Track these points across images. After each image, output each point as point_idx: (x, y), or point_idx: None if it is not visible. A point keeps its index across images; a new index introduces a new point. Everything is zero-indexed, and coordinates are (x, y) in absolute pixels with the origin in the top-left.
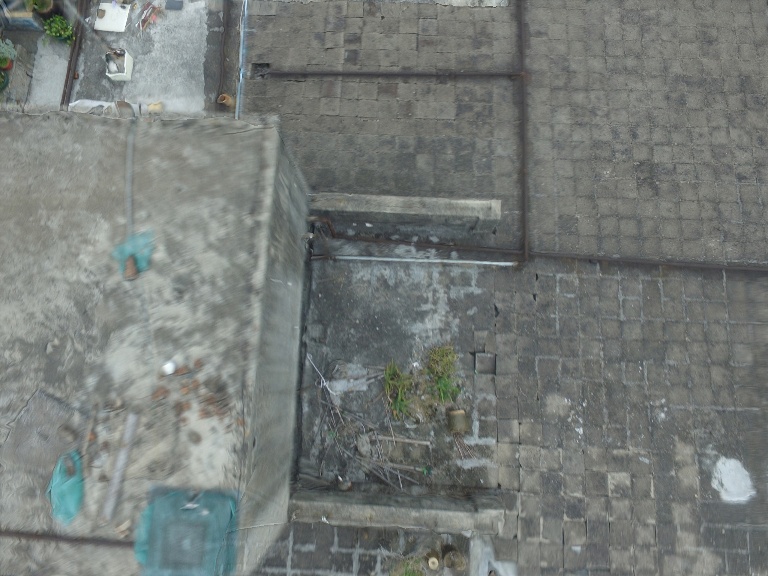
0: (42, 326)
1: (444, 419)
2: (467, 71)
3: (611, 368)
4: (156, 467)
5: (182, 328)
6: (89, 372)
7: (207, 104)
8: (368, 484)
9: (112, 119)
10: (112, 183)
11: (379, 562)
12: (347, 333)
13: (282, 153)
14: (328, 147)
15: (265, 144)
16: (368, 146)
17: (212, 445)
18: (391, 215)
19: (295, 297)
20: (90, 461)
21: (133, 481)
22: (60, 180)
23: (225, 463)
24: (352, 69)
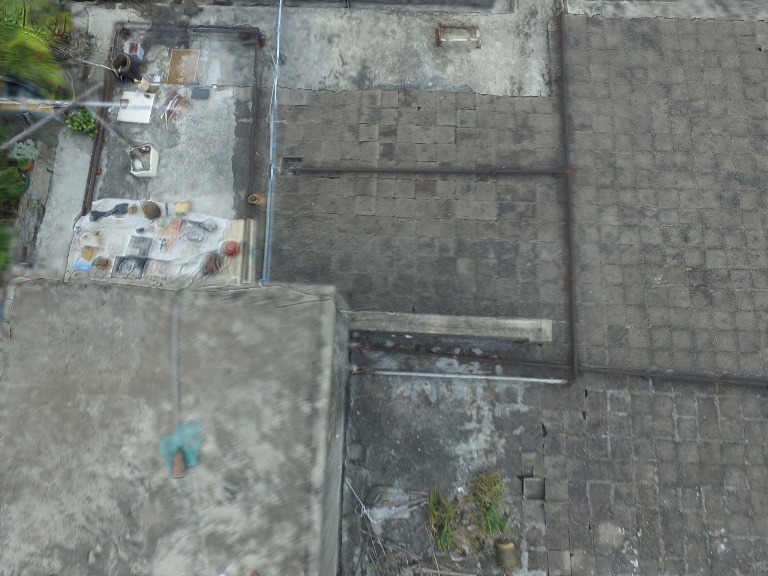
0: (83, 530)
1: (491, 550)
2: (509, 168)
3: (666, 494)
4: None
5: (235, 533)
6: None
7: (236, 202)
8: None
9: (155, 290)
10: (156, 363)
11: None
12: (387, 455)
13: (337, 320)
14: (364, 250)
15: (321, 319)
16: (406, 249)
17: None
18: (435, 334)
19: None
20: None
21: None
22: (100, 359)
23: None
24: (388, 165)
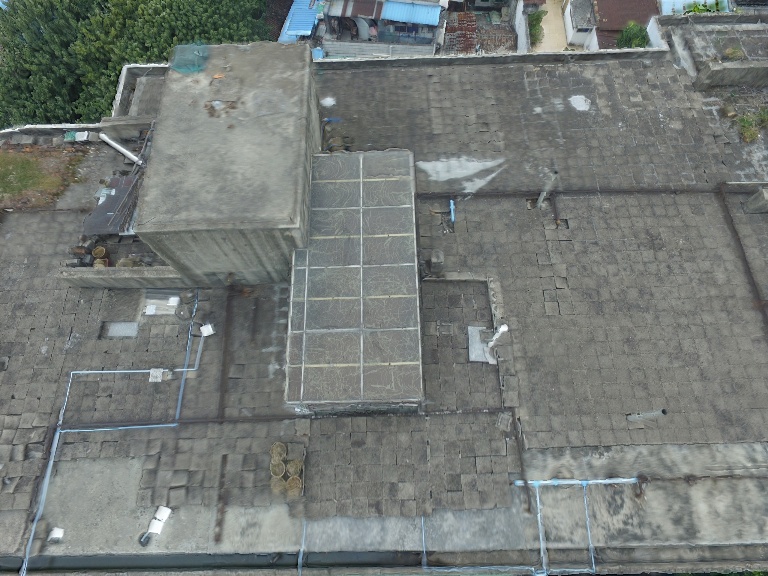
0: None
1: None
2: None
3: (652, 142)
4: None
5: None
6: None
7: None
8: None
9: None
10: None
11: None
12: None
13: None
14: None
15: None
16: None
17: None
18: None
19: None
20: None
21: None
22: None
23: None
24: None
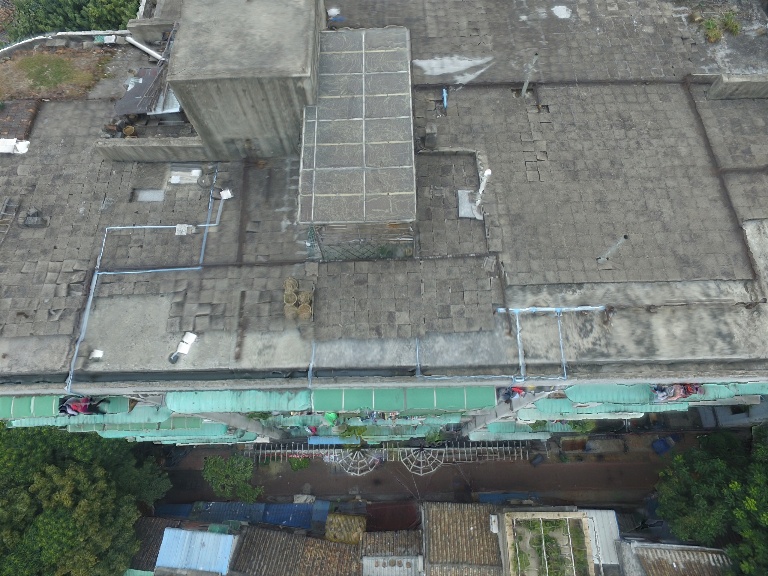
0: None
1: None
2: None
3: (626, 43)
4: None
5: None
6: None
7: None
8: None
9: None
10: None
11: None
12: (763, 46)
13: None
14: None
15: None
16: None
17: None
18: None
19: None
20: None
21: None
22: None
23: None
24: None
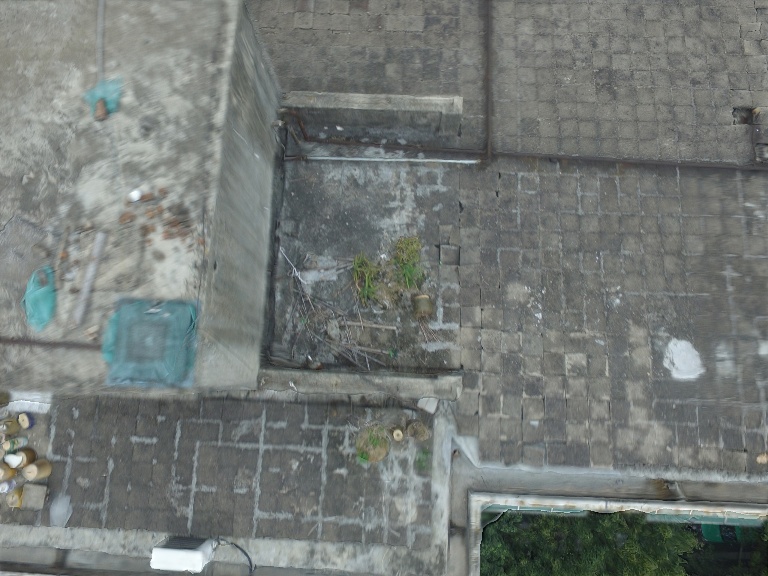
0: (18, 161)
1: (410, 306)
2: None
3: (569, 258)
4: (122, 279)
5: (148, 162)
6: (62, 201)
7: None
8: (337, 367)
9: None
10: (84, 36)
11: (347, 437)
12: (318, 228)
13: (245, 15)
14: (301, 58)
15: (227, 1)
16: (340, 56)
17: (175, 262)
18: (359, 112)
19: (264, 178)
20: (62, 274)
21: (101, 293)
22: (36, 34)
23: (186, 277)
24: None
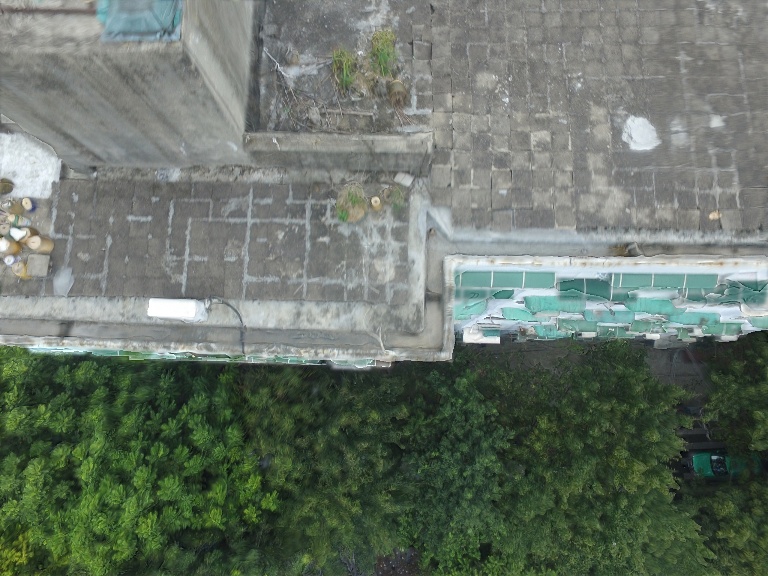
0: None
1: (386, 95)
2: None
3: (534, 50)
4: None
5: None
6: None
7: None
8: None
9: None
10: None
11: (329, 209)
12: (299, 31)
13: None
14: None
15: None
16: None
17: None
18: None
19: None
20: None
21: None
22: None
23: None
24: None
